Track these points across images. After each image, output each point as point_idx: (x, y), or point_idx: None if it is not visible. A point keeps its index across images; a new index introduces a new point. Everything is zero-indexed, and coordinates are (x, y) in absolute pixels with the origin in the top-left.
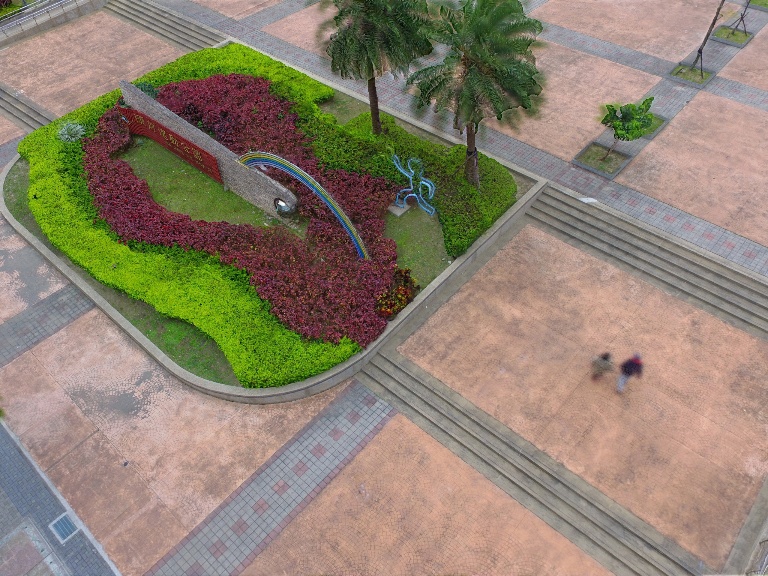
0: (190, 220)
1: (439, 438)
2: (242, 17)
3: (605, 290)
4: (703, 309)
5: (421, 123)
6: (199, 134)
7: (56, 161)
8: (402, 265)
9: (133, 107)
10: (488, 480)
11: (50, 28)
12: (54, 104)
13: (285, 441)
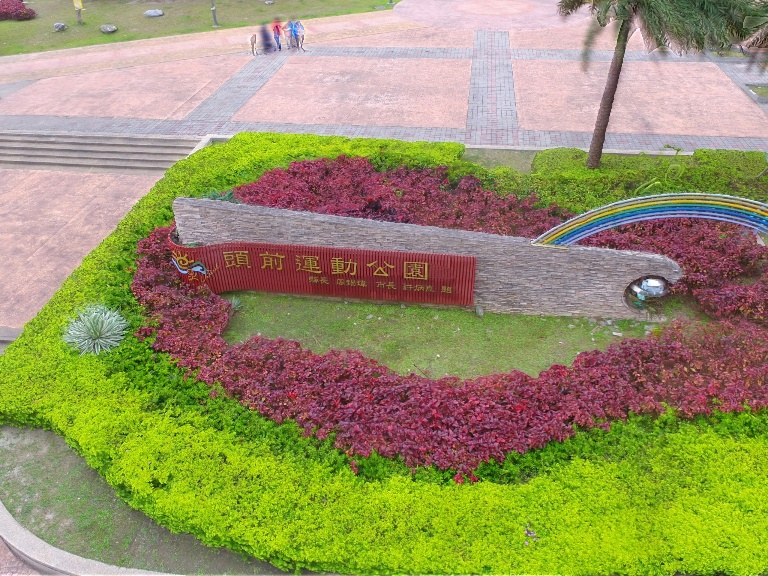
0: None
1: None
2: (183, 115)
3: None
4: None
5: None
6: (421, 230)
7: (118, 394)
8: None
9: (207, 243)
10: None
11: None
12: None
13: None
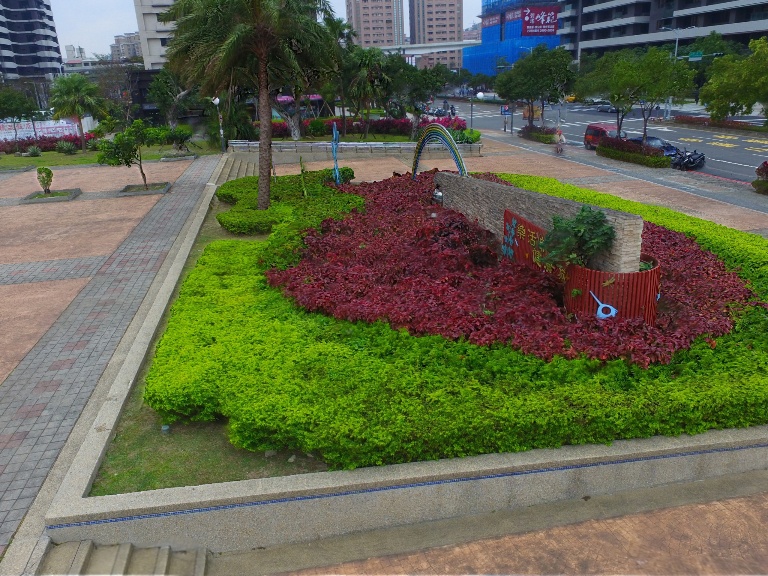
0: None
1: None
2: None
3: None
4: None
5: None
6: None
7: None
8: None
9: None
10: None
11: None
12: None
13: None
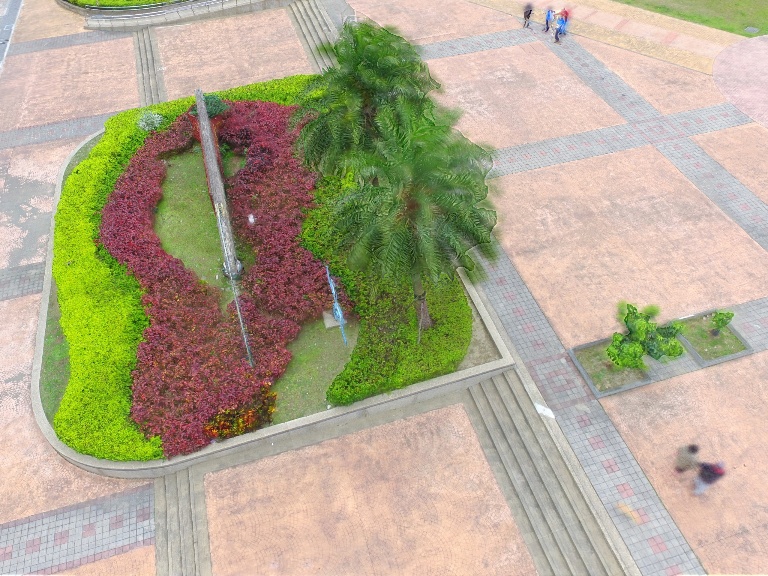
0: (157, 245)
1: None
2: None
3: (471, 537)
4: None
5: None
6: (210, 165)
7: (119, 144)
8: (284, 384)
9: None
10: None
11: (234, 14)
12: (175, 88)
13: (48, 509)
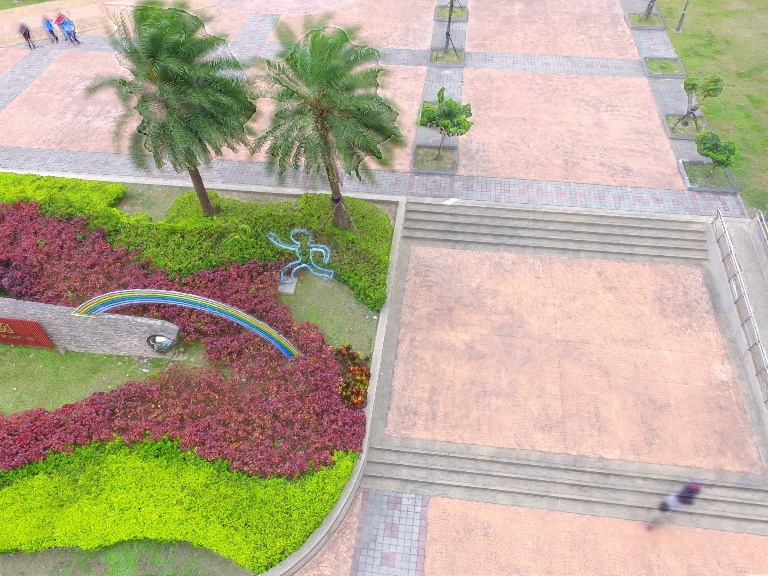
0: (47, 413)
1: (484, 499)
2: None
3: (517, 278)
4: (597, 258)
5: (244, 186)
6: None
7: None
8: (331, 343)
9: None
10: (553, 512)
11: None
12: None
13: None
